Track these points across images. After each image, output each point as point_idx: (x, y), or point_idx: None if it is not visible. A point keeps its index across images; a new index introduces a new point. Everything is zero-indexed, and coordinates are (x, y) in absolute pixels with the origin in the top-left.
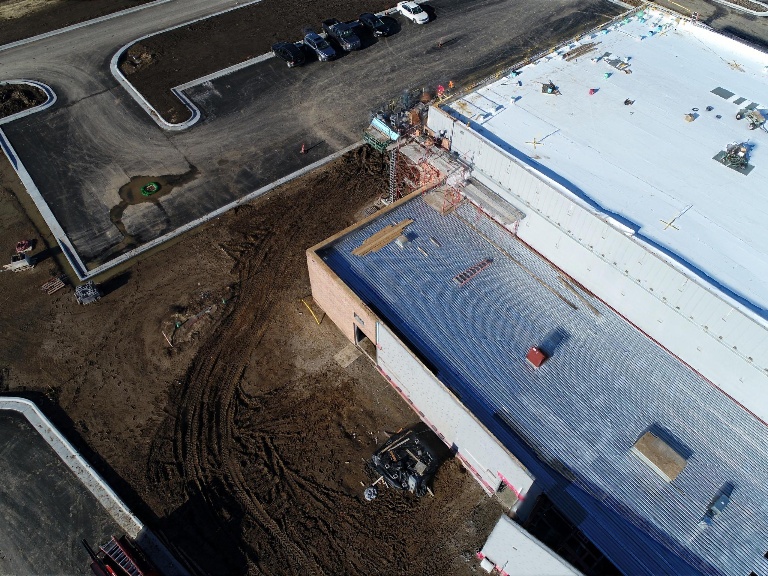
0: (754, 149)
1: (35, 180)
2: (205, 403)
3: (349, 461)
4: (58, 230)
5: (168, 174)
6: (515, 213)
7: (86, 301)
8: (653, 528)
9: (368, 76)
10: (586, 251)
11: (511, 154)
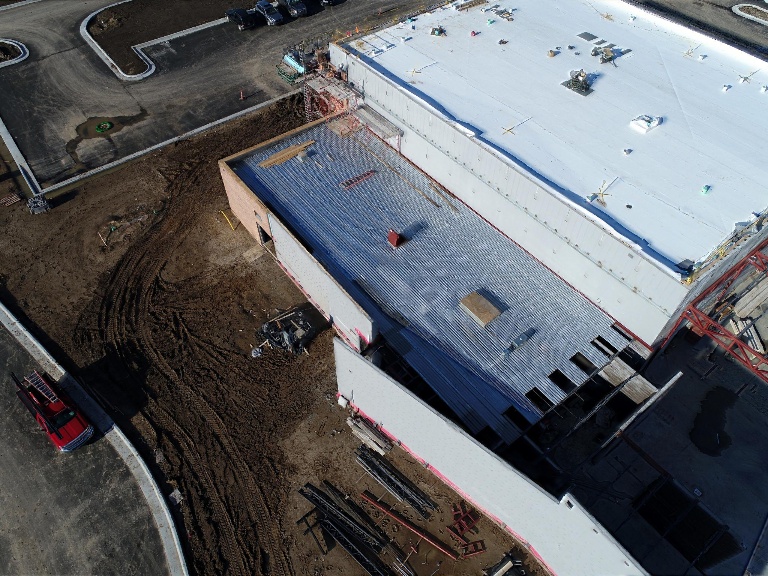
0: (598, 77)
1: (4, 119)
2: (129, 287)
3: (243, 329)
4: (19, 158)
5: (121, 115)
6: (394, 130)
7: (37, 211)
8: (463, 358)
9: None
10: (445, 156)
11: (389, 79)
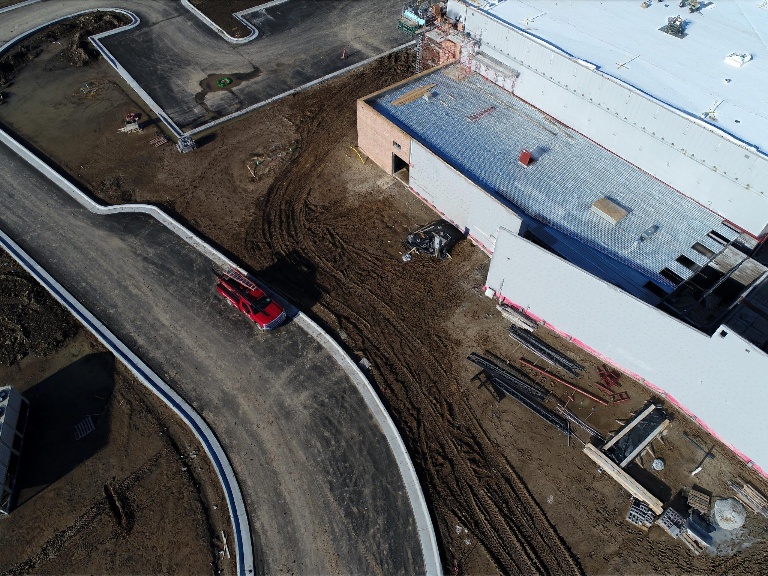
0: (690, 24)
1: (132, 75)
2: (283, 209)
3: (390, 240)
4: (156, 107)
5: (237, 72)
6: (512, 71)
7: (186, 150)
8: (602, 247)
9: (394, 6)
10: (563, 90)
11: (509, 25)
